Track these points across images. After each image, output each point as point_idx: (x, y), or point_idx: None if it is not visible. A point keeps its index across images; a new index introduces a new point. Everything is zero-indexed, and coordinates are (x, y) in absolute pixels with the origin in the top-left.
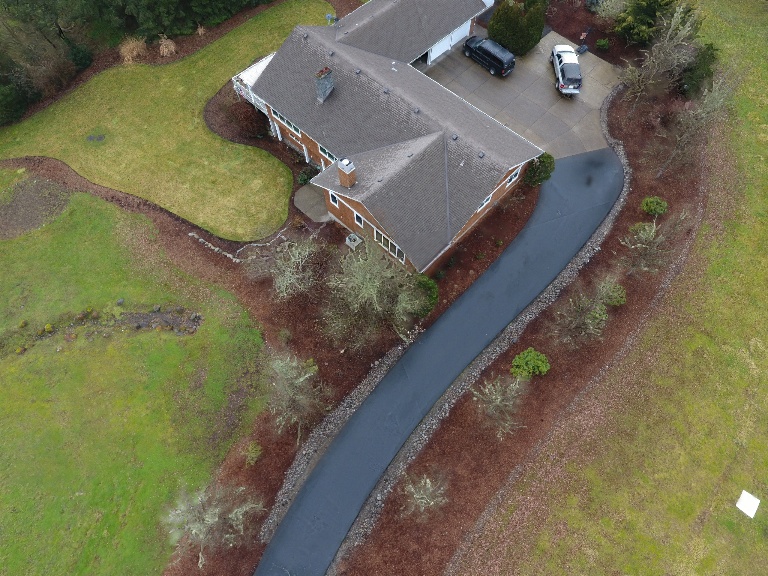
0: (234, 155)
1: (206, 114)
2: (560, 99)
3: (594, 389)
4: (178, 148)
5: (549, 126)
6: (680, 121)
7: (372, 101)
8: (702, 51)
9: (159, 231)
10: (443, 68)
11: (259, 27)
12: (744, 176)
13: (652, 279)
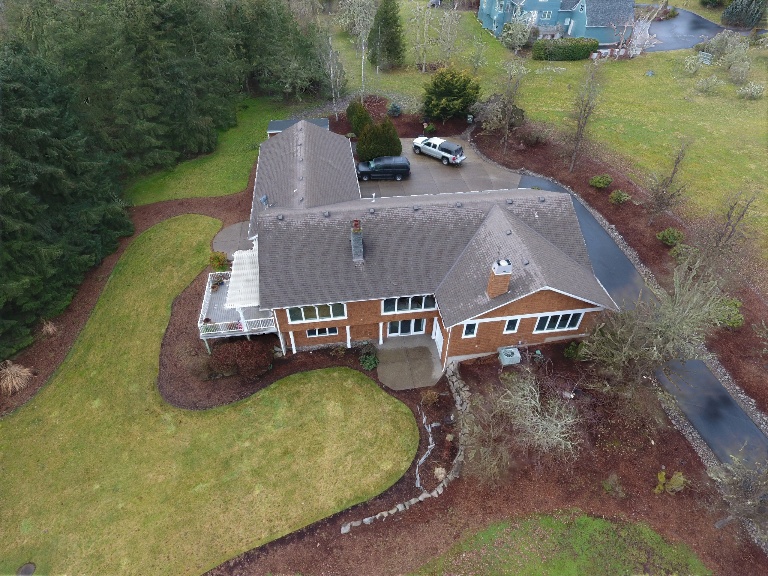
0: (268, 407)
1: (172, 400)
2: (457, 169)
3: (761, 291)
4: (185, 464)
5: (479, 186)
6: (538, 136)
7: (412, 224)
8: (493, 100)
9: (301, 574)
10: (363, 197)
11: (135, 275)
12: (599, 143)
13: (662, 216)
